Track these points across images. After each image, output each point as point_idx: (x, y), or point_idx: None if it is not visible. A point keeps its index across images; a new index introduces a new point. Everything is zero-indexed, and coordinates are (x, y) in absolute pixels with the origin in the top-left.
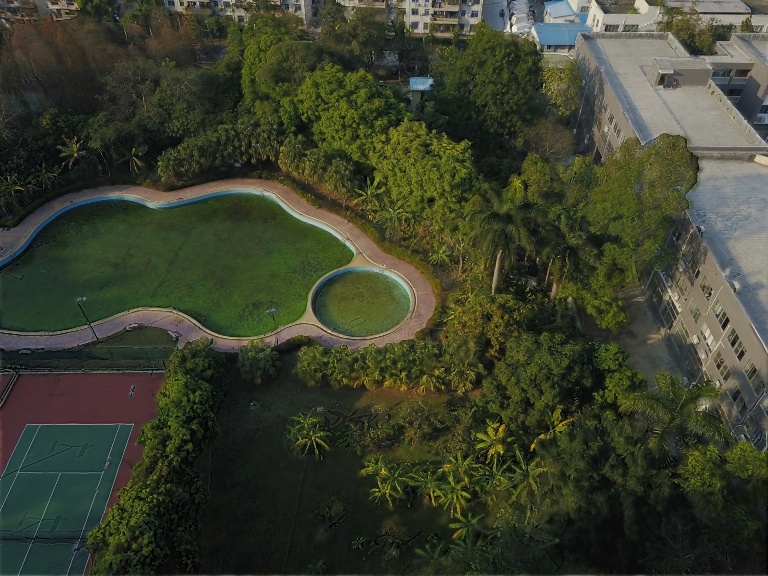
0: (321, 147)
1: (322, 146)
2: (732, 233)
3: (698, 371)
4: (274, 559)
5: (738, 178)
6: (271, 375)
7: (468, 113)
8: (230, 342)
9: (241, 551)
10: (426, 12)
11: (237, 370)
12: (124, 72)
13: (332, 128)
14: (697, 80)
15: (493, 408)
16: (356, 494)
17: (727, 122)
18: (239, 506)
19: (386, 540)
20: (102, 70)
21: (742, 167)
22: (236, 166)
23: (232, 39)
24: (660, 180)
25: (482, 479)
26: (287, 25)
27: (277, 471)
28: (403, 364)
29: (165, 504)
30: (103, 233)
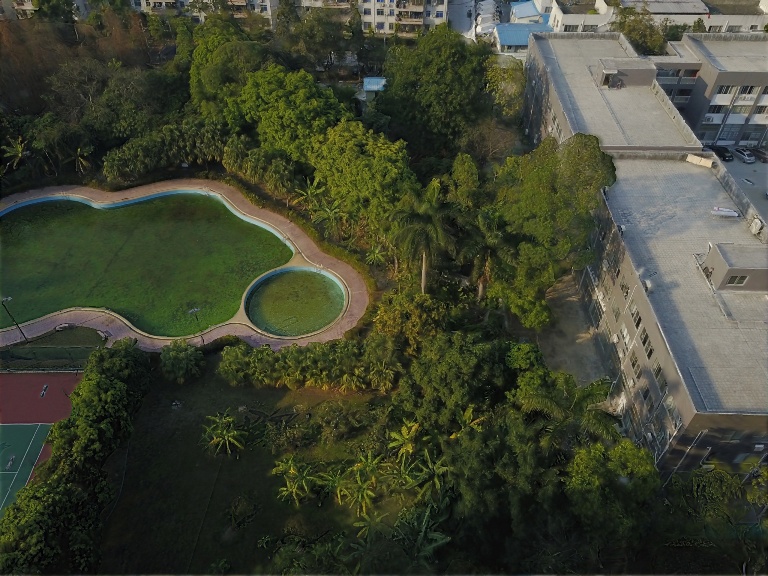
0: (262, 147)
1: (263, 146)
2: (654, 232)
3: (618, 370)
4: (179, 558)
5: (668, 178)
6: (194, 375)
7: (412, 113)
8: (159, 342)
9: (147, 550)
10: (391, 12)
11: (160, 370)
12: (70, 72)
13: (272, 128)
14: (642, 80)
15: (407, 407)
16: (268, 493)
17: (667, 122)
18: (150, 505)
19: (293, 539)
20: (49, 70)
21: (674, 167)
22: (183, 166)
23: (181, 39)
24: (570, 179)
25: (389, 478)
26: (253, 25)
27: (192, 470)
28: (323, 363)
29: (62, 503)
30: (45, 233)
